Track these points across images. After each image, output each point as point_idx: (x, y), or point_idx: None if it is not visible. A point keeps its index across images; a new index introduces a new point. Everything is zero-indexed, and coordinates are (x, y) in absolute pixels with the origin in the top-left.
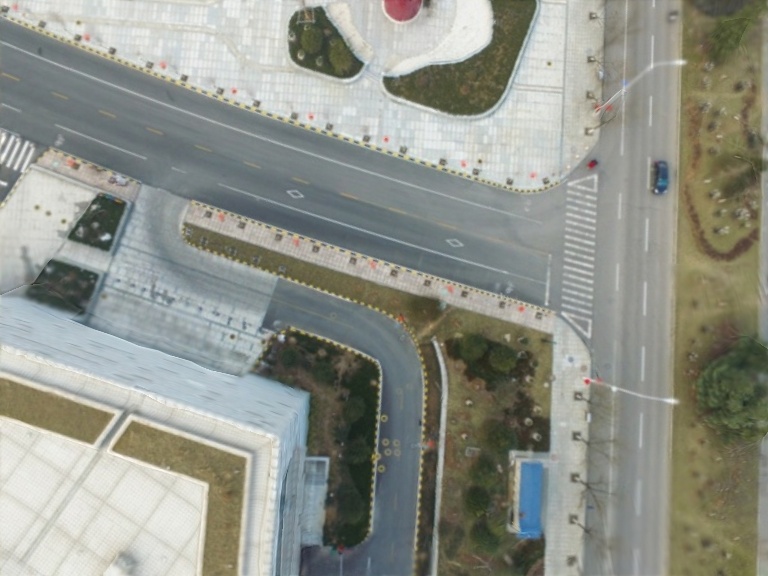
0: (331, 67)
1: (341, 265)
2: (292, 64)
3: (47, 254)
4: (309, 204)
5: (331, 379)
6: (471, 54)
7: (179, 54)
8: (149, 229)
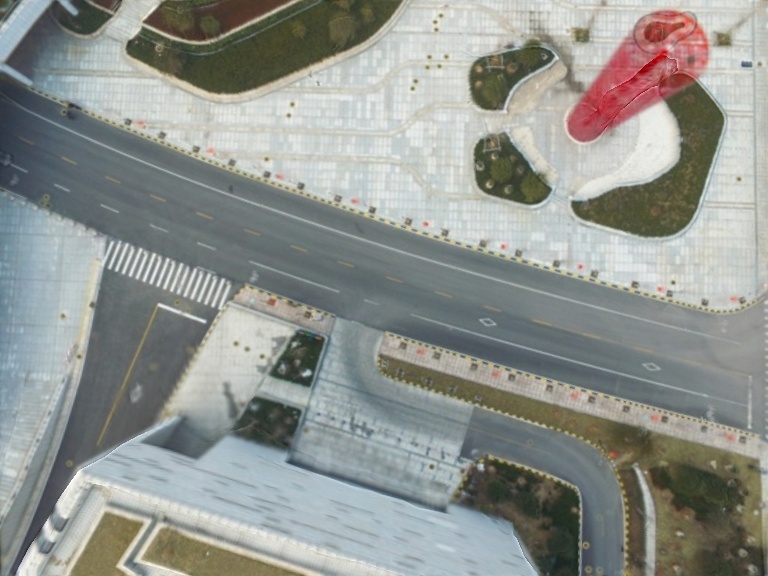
0: (522, 196)
1: (538, 393)
2: (479, 192)
3: (248, 390)
4: (502, 332)
5: (533, 508)
6: (659, 173)
7: (366, 186)
8: (345, 362)
